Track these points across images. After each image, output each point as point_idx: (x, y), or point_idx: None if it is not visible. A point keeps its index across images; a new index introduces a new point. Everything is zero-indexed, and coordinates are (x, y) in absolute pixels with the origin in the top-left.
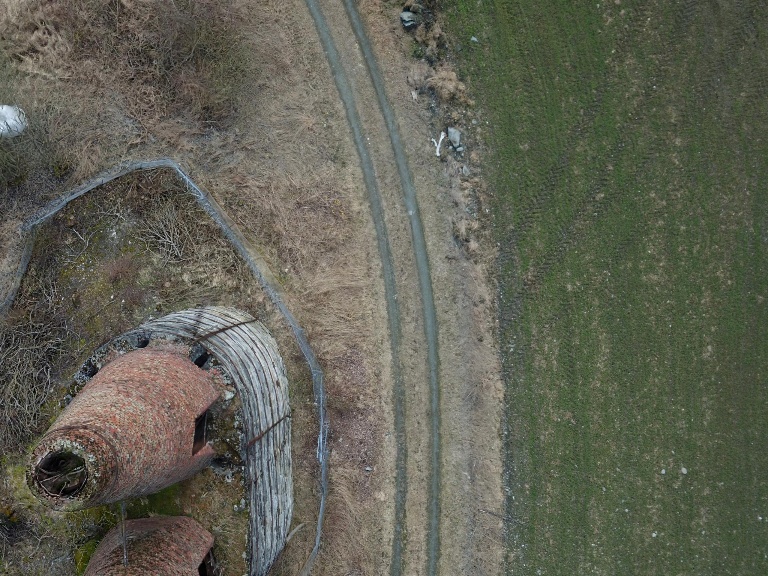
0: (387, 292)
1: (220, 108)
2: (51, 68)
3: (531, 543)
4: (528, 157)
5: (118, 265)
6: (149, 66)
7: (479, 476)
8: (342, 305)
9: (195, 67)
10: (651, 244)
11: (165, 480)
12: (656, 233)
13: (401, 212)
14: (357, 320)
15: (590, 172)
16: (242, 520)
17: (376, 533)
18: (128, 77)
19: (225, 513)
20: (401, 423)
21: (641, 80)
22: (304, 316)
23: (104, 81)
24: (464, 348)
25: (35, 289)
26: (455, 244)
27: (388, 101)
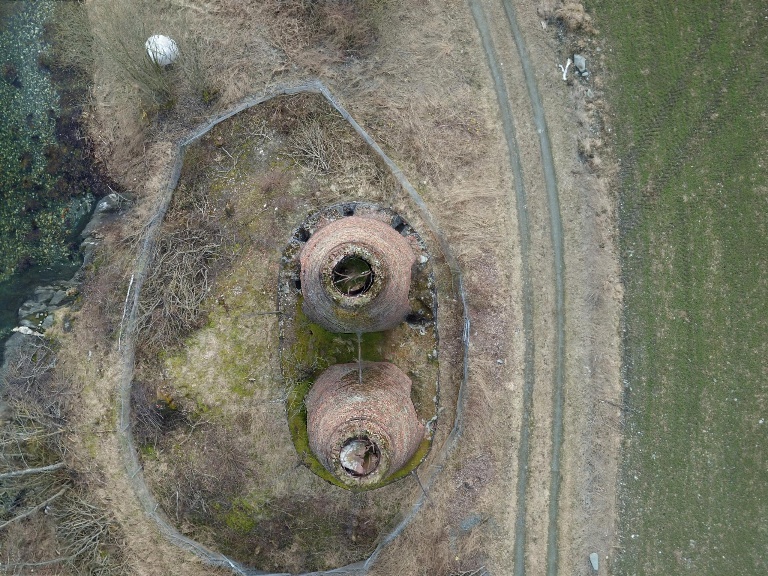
0: (518, 202)
1: (362, 37)
2: (201, 2)
3: (647, 430)
4: (648, 81)
5: (269, 177)
6: (294, 0)
7: (599, 370)
8: (478, 213)
9: (338, 1)
10: (761, 159)
11: (393, 314)
12: (766, 149)
13: (531, 130)
14: (491, 227)
15: (706, 94)
16: (434, 368)
17: (506, 420)
18: (274, 10)
19: (421, 360)
20: (529, 321)
21: (754, 11)
22: (443, 223)
23: (251, 14)
24: (587, 254)
25: (186, 203)
26: (579, 160)
27: (520, 30)
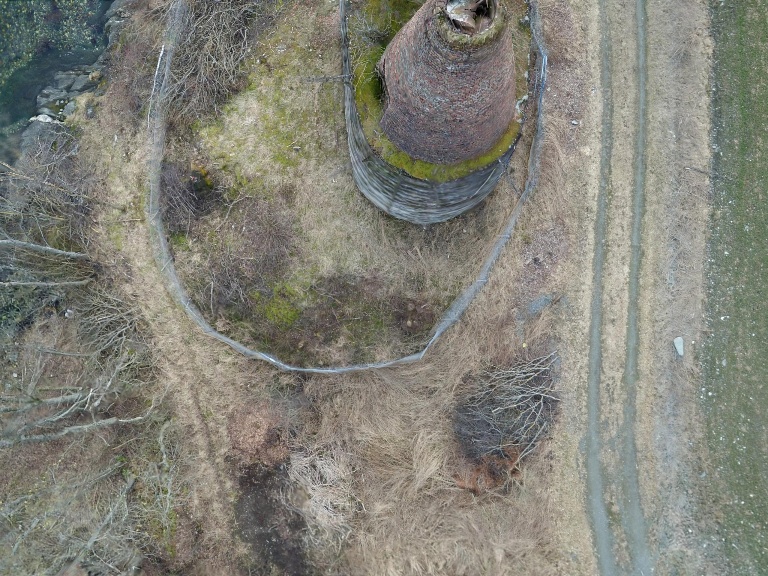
0: None
1: None
2: None
3: (739, 199)
4: None
5: None
6: None
7: (685, 134)
8: None
9: None
10: None
11: None
12: None
13: None
14: None
15: None
16: (526, 38)
17: (581, 188)
18: None
19: (512, 24)
20: (607, 78)
21: None
22: None
23: None
24: (671, 6)
25: None
26: None
27: None
